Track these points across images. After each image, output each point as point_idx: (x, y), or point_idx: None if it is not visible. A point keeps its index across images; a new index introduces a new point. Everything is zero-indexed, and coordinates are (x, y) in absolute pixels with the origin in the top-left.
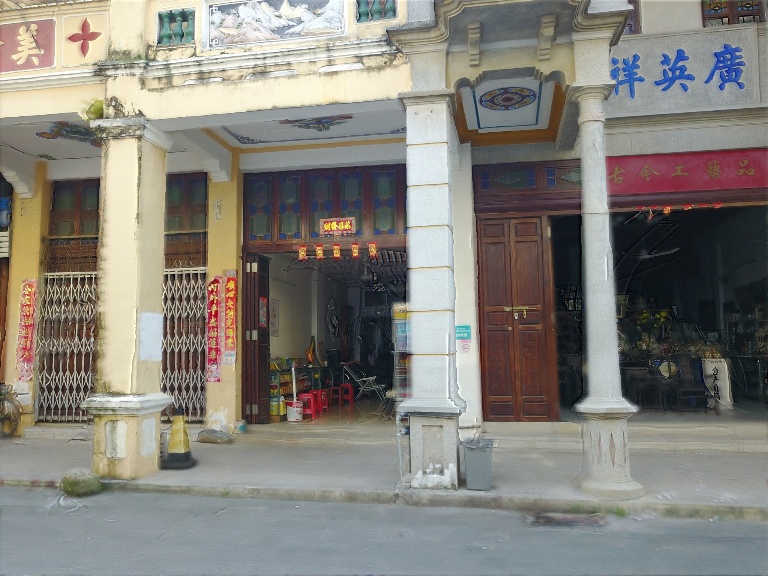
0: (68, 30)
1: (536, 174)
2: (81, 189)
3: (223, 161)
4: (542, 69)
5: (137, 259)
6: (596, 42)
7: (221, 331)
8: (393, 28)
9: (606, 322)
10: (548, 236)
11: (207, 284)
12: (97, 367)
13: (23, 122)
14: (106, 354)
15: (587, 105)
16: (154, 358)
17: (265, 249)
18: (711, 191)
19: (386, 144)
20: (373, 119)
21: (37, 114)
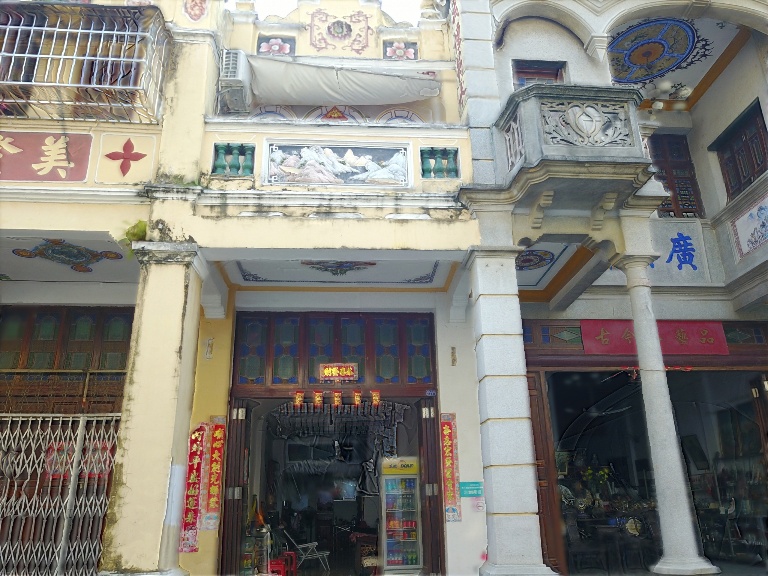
0: (107, 147)
1: (532, 331)
2: (35, 316)
3: (223, 297)
4: (595, 237)
5: (176, 399)
6: (638, 219)
7: (204, 488)
8: (467, 187)
9: (682, 477)
10: (546, 391)
11: (190, 432)
12: (111, 535)
13: (19, 236)
14: (126, 518)
15: (635, 272)
16: (178, 522)
17: (258, 394)
18: (682, 355)
19: (393, 292)
20: (395, 267)
21: (57, 229)
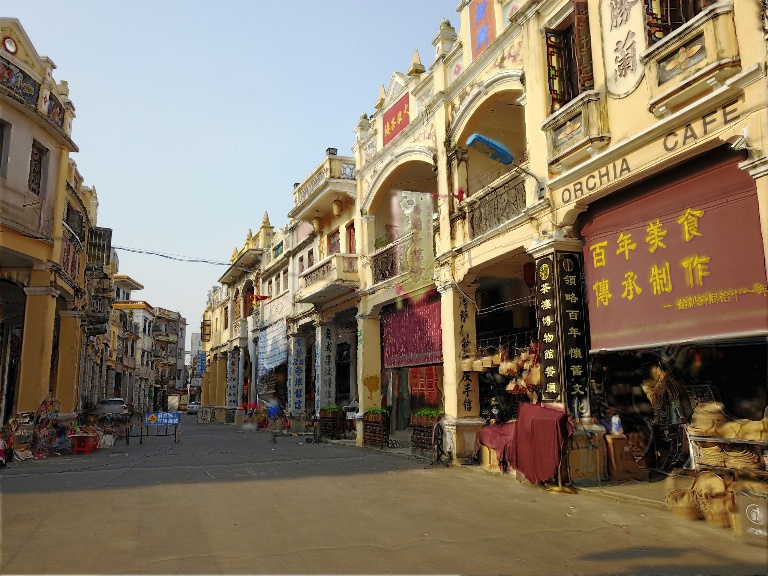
0: None
1: None
2: None
3: None
4: None
5: None
6: None
7: None
8: None
9: None
10: None
11: None
12: None
13: None
14: None
15: None
16: None
17: None
18: None
19: None
20: None
21: None
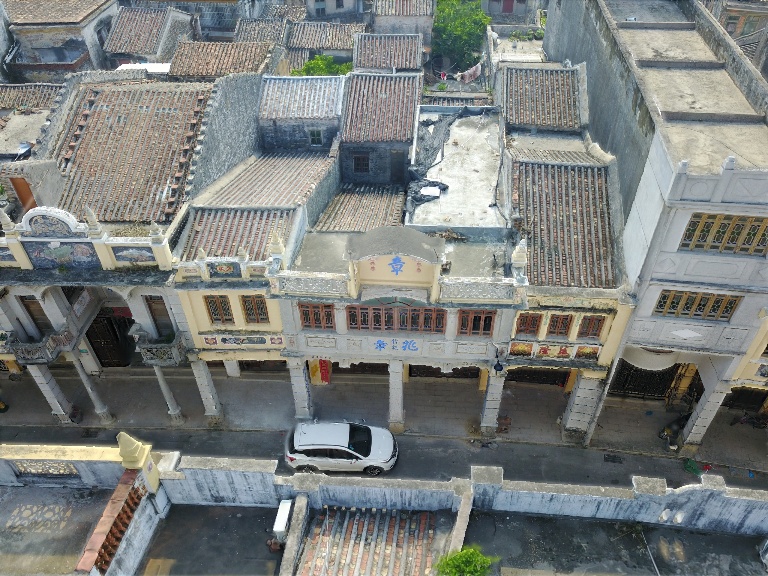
0: None
1: None
2: None
3: None
4: None
5: None
6: None
7: None
8: None
9: (94, 398)
10: None
11: None
12: None
13: None
14: None
15: None
16: None
17: None
18: None
19: None
20: None
21: None
